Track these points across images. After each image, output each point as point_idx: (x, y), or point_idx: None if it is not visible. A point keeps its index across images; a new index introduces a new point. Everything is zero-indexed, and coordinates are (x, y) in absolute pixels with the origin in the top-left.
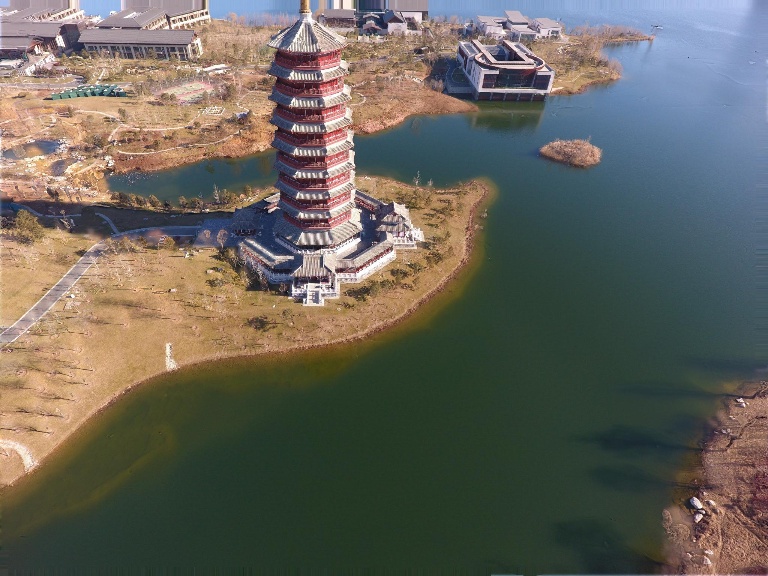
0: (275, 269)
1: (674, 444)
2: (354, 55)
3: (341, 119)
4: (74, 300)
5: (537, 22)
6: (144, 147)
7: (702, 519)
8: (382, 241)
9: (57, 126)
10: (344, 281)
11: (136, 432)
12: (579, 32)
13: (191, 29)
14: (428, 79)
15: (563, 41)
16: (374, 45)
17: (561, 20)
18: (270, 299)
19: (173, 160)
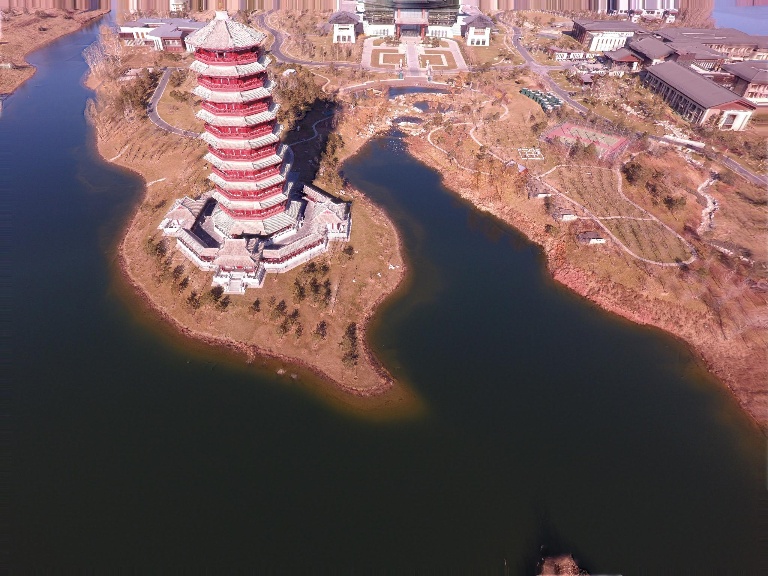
0: None
1: None
2: None
3: None
4: None
5: None
6: None
7: None
8: None
9: None
10: None
11: (111, 182)
12: None
13: None
14: None
15: None
16: None
17: None
18: None
19: (425, 155)
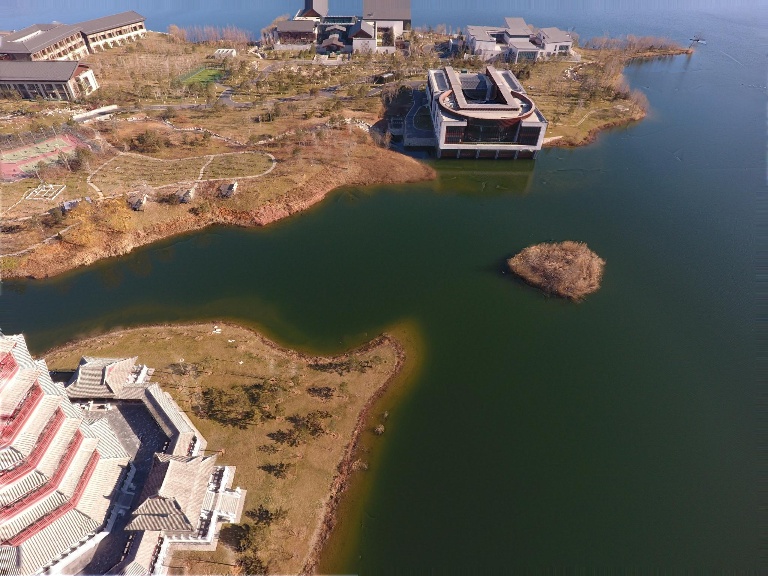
0: None
1: None
2: (294, 87)
3: None
4: None
5: (542, 33)
6: None
7: None
8: (125, 563)
9: None
10: None
11: None
12: (597, 45)
13: (117, 48)
14: (381, 123)
15: (574, 59)
16: (323, 72)
17: (574, 30)
18: None
19: None
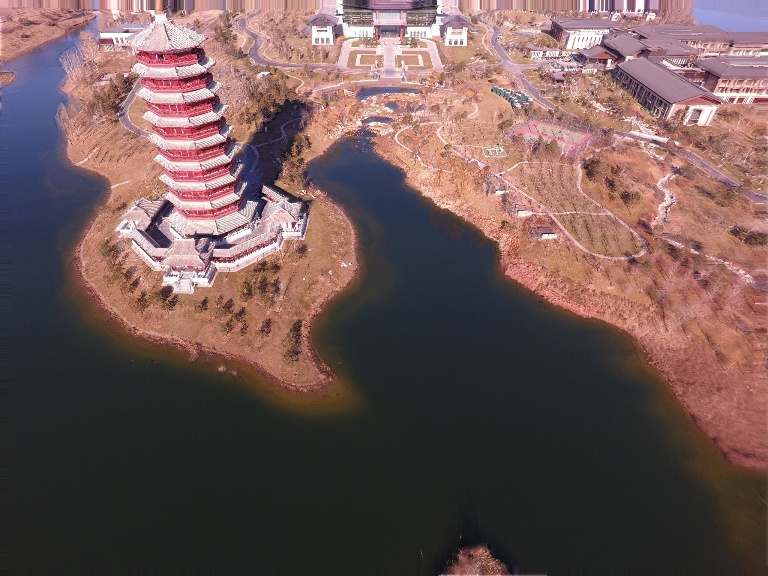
0: None
1: None
2: None
3: None
4: None
5: None
6: None
7: None
8: (158, 247)
9: None
10: None
11: None
12: None
13: None
14: None
15: None
16: None
17: None
18: None
19: (391, 154)
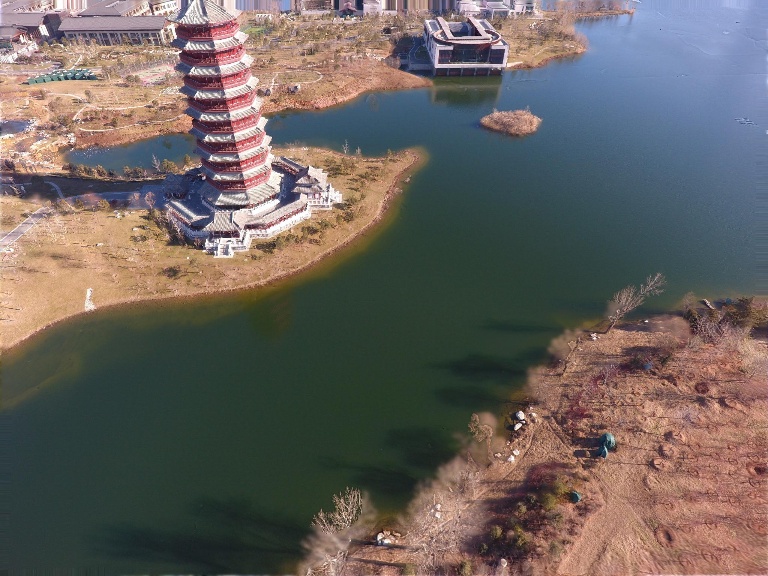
0: (193, 226)
1: (519, 370)
2: (323, 36)
3: (243, 86)
4: (12, 253)
5: None
6: (104, 125)
7: (520, 427)
8: (295, 201)
9: (29, 108)
10: (256, 237)
11: (49, 359)
12: (557, 8)
13: None
14: None
15: (537, 17)
16: (344, 26)
17: None
18: (186, 252)
19: (130, 136)
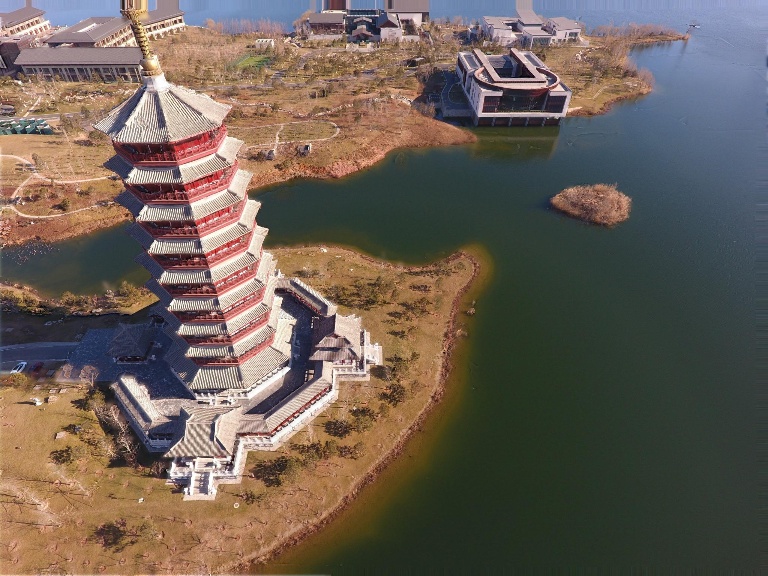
0: None
1: None
2: (336, 69)
3: (233, 226)
4: None
5: (553, 22)
6: (51, 207)
7: None
8: (315, 379)
9: None
10: (254, 446)
11: None
12: (601, 32)
13: (161, 40)
14: (420, 99)
15: (583, 44)
16: (360, 57)
17: (581, 19)
18: (139, 485)
19: (84, 225)
